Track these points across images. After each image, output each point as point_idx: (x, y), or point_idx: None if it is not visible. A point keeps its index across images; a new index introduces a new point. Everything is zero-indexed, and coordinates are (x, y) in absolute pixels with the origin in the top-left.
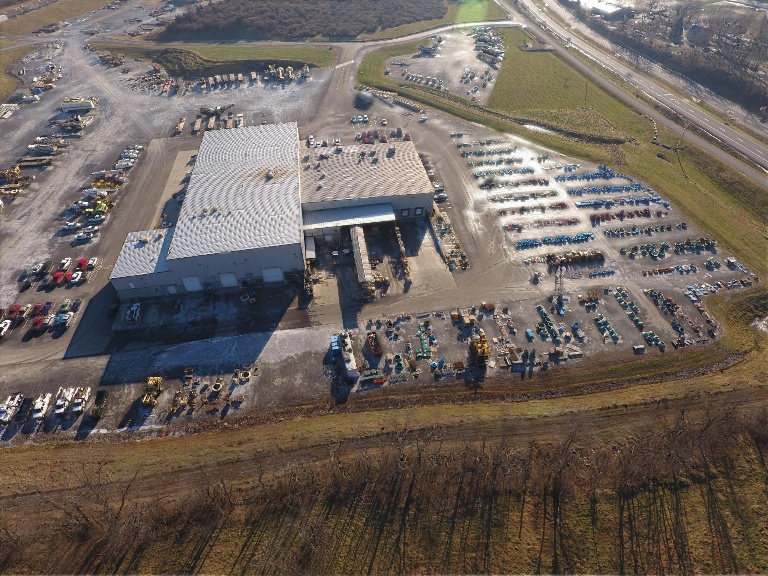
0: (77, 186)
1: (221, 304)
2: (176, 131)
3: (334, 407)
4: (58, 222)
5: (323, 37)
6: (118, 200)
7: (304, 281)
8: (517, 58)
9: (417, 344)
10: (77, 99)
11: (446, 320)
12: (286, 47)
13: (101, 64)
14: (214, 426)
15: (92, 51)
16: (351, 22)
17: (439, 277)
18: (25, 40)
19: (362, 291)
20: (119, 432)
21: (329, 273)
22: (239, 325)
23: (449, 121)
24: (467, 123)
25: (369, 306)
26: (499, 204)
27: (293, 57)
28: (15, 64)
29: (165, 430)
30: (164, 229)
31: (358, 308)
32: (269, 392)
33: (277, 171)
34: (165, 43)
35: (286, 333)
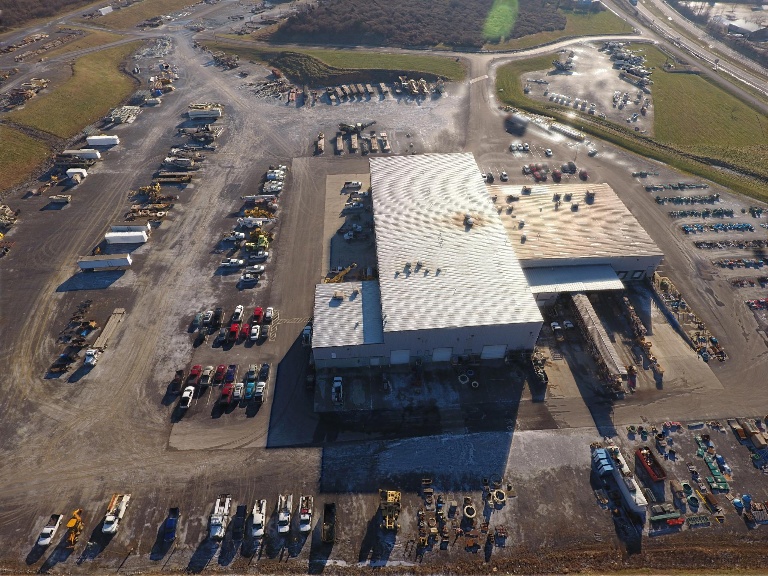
0: (225, 211)
1: (436, 385)
2: (318, 150)
3: (628, 557)
4: (215, 256)
5: (446, 46)
6: (276, 232)
7: (533, 363)
8: (665, 80)
9: (704, 468)
10: (202, 105)
11: (728, 435)
12: (410, 56)
13: (216, 65)
14: (481, 571)
15: (203, 50)
16: (472, 30)
17: (694, 369)
18: (132, 34)
19: (607, 382)
20: (362, 567)
21: (554, 352)
22: (468, 418)
23: (623, 156)
24: (645, 159)
25: (621, 404)
26: (729, 271)
27: (422, 68)
28: (127, 61)
29: (419, 571)
30: (357, 283)
31: (608, 406)
32: (536, 525)
33: (475, 217)
34: (279, 45)
35: (530, 436)
